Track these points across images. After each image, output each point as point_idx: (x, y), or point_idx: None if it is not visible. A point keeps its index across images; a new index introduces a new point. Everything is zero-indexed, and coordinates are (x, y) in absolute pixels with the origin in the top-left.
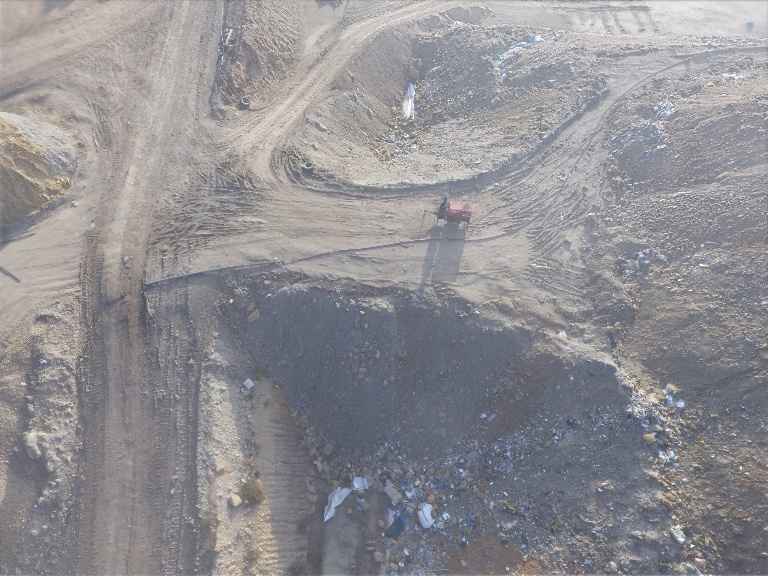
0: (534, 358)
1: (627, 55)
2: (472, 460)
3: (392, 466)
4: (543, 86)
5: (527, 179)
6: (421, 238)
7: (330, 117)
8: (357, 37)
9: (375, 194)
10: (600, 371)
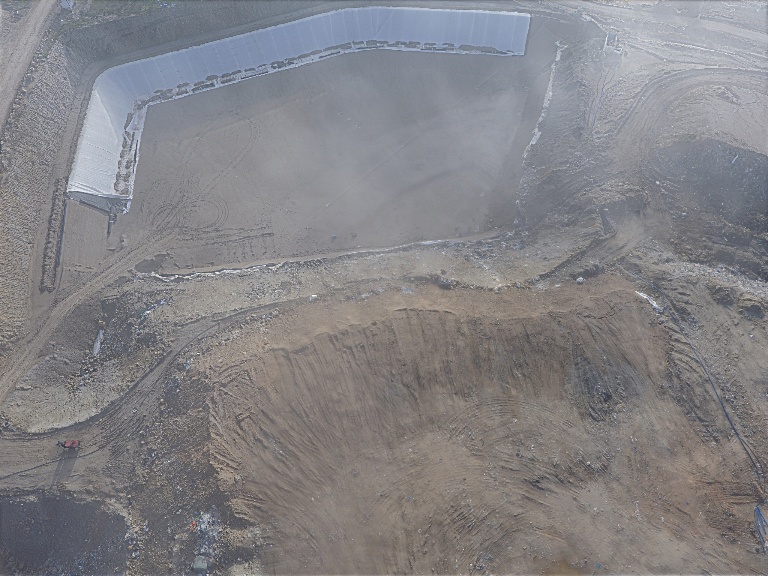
0: (100, 514)
1: (188, 324)
2: (84, 561)
3: (52, 569)
4: (147, 345)
5: (117, 414)
6: (56, 459)
7: (34, 378)
8: (61, 313)
9: (38, 436)
10: (120, 518)
